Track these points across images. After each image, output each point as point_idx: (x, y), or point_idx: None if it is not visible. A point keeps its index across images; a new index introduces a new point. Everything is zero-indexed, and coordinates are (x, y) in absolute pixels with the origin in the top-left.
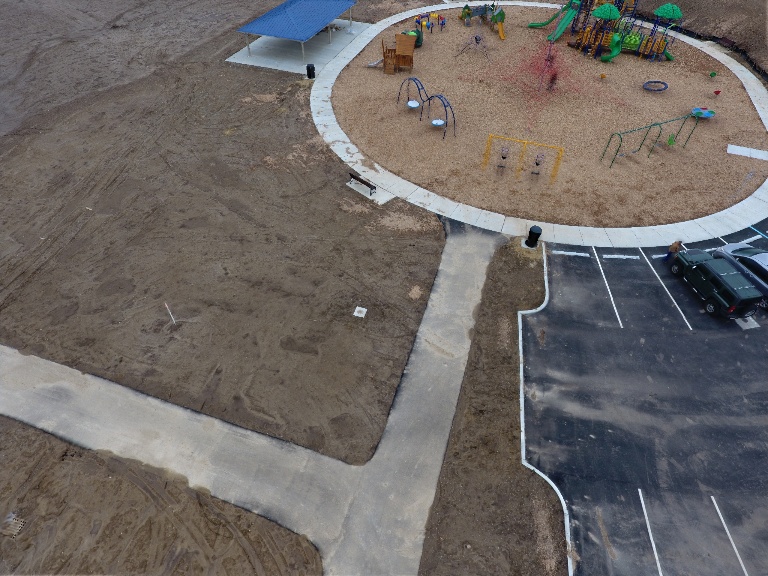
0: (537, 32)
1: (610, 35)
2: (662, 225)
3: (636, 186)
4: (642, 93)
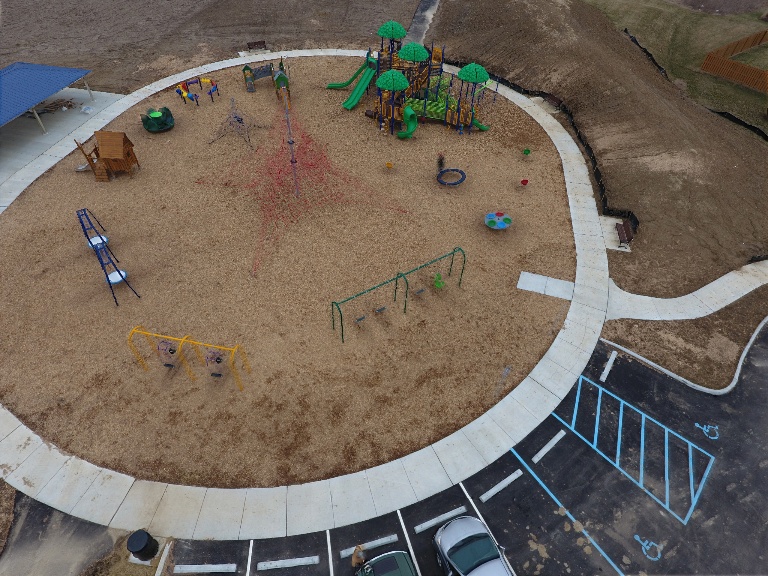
0: (336, 95)
1: (401, 108)
2: (381, 465)
3: (369, 377)
4: (434, 188)
